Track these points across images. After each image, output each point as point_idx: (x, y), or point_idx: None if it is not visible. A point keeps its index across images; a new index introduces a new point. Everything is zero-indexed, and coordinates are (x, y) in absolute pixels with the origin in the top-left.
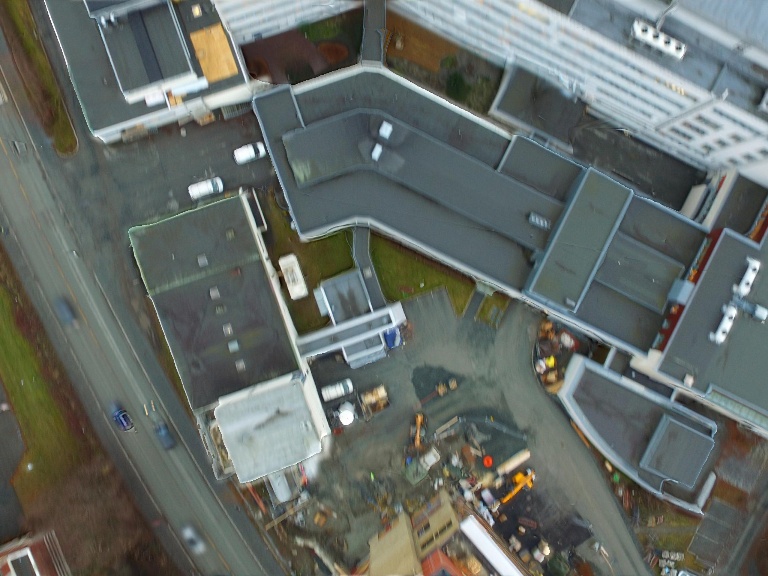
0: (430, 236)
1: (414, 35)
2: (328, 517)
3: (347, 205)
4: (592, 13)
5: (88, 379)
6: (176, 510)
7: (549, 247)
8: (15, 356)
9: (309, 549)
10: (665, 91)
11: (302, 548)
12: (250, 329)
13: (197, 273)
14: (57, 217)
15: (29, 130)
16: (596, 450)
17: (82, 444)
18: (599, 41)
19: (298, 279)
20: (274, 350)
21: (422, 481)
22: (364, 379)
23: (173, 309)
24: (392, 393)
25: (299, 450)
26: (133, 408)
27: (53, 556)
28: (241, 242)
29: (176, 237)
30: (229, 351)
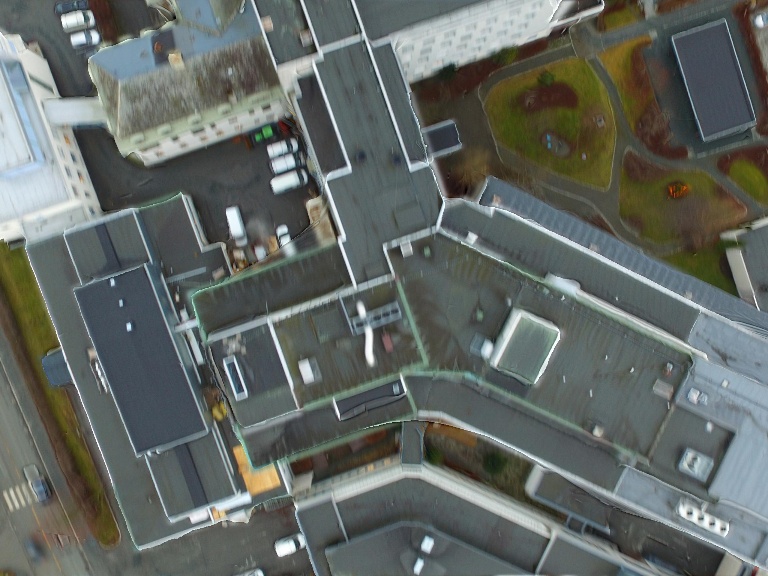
0: None
1: None
2: None
3: None
4: (637, 487)
5: None
6: None
7: None
8: None
9: None
10: None
11: None
12: None
13: None
14: None
15: (72, 523)
16: None
17: None
18: (643, 511)
19: None
20: None
21: None
22: None
23: None
24: None
25: None
26: None
27: None
28: None
29: None
30: None
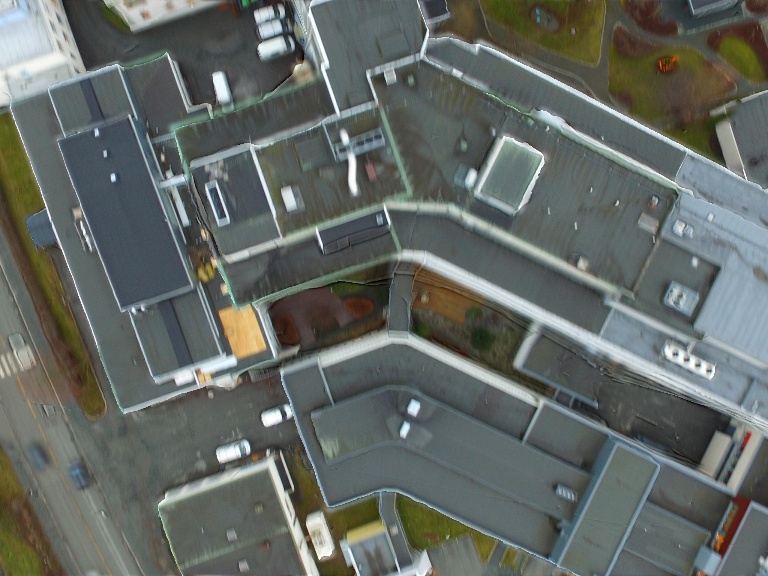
0: (457, 506)
1: (440, 292)
2: None
3: (375, 477)
4: (622, 331)
5: None
6: None
7: (576, 523)
8: None
9: None
10: (694, 393)
11: None
12: None
13: (226, 547)
14: (85, 478)
15: (57, 393)
16: None
17: None
18: (629, 356)
19: (325, 541)
20: None
21: None
22: None
23: None
24: None
25: None
26: None
27: None
28: (270, 515)
29: (205, 511)
30: None
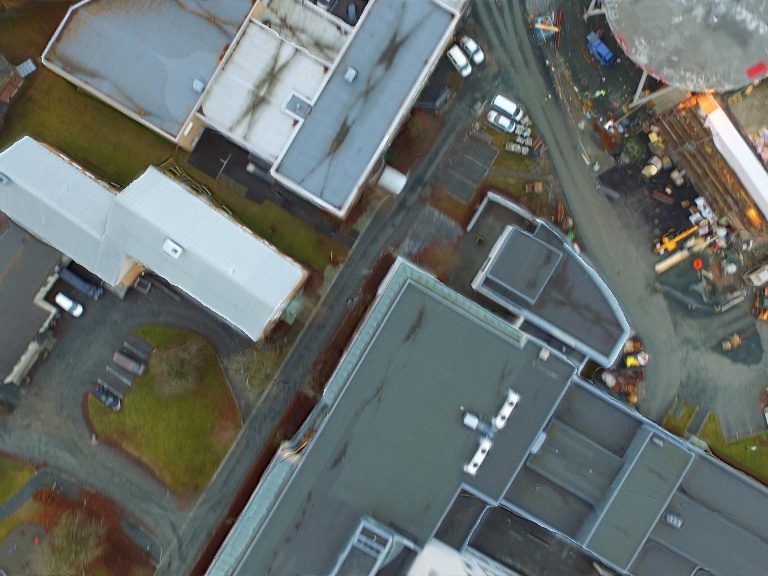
0: None
1: None
2: None
3: None
4: None
5: None
6: None
7: None
8: None
9: None
10: None
11: None
12: None
13: None
14: None
15: None
16: None
17: None
18: None
19: None
20: None
21: (763, 250)
22: None
23: None
24: None
25: None
26: None
27: None
28: None
29: None
30: None
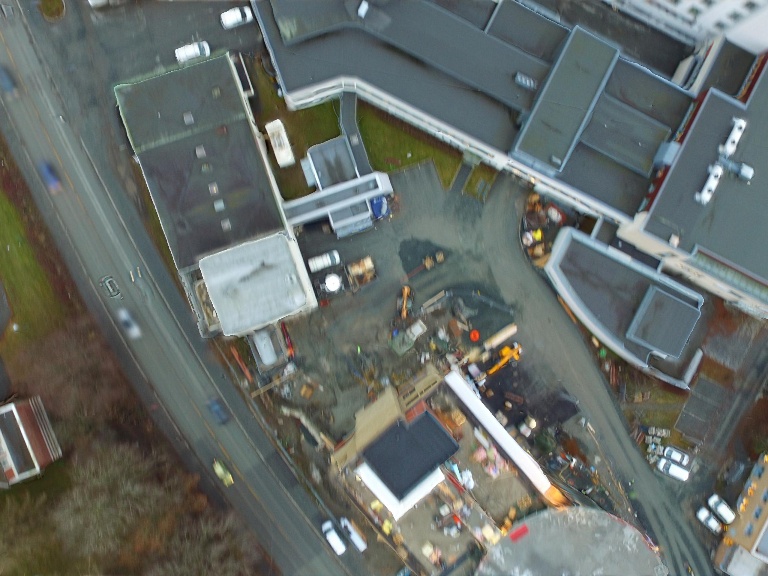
0: (416, 97)
1: None
2: (314, 390)
3: (333, 64)
4: None
5: (74, 244)
6: (162, 377)
7: (535, 105)
8: (1, 221)
9: (295, 419)
10: None
11: (288, 417)
12: (236, 189)
13: (183, 131)
14: (44, 81)
15: None
16: (583, 326)
17: (68, 310)
18: None
19: (285, 143)
20: (260, 211)
21: (409, 355)
22: (351, 251)
23: (159, 167)
24: (379, 266)
25: (284, 303)
26: (119, 274)
27: (38, 419)
28: (227, 101)
29: (162, 95)
30: (215, 210)
